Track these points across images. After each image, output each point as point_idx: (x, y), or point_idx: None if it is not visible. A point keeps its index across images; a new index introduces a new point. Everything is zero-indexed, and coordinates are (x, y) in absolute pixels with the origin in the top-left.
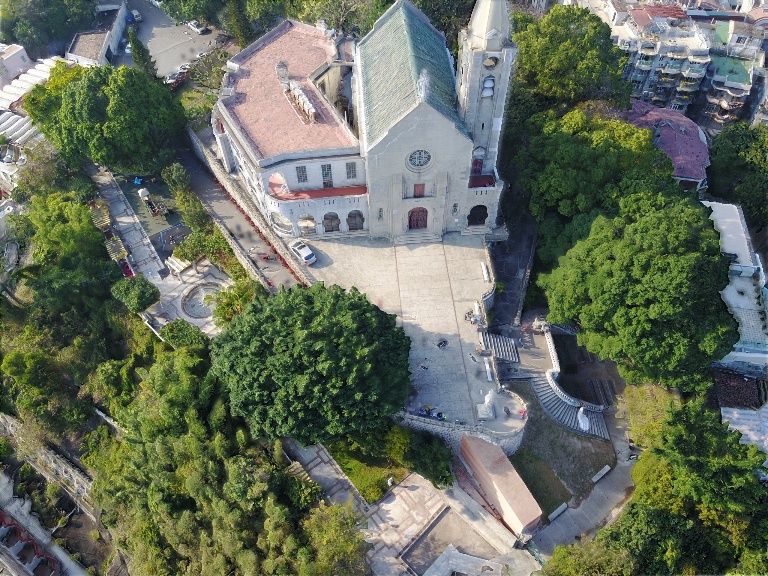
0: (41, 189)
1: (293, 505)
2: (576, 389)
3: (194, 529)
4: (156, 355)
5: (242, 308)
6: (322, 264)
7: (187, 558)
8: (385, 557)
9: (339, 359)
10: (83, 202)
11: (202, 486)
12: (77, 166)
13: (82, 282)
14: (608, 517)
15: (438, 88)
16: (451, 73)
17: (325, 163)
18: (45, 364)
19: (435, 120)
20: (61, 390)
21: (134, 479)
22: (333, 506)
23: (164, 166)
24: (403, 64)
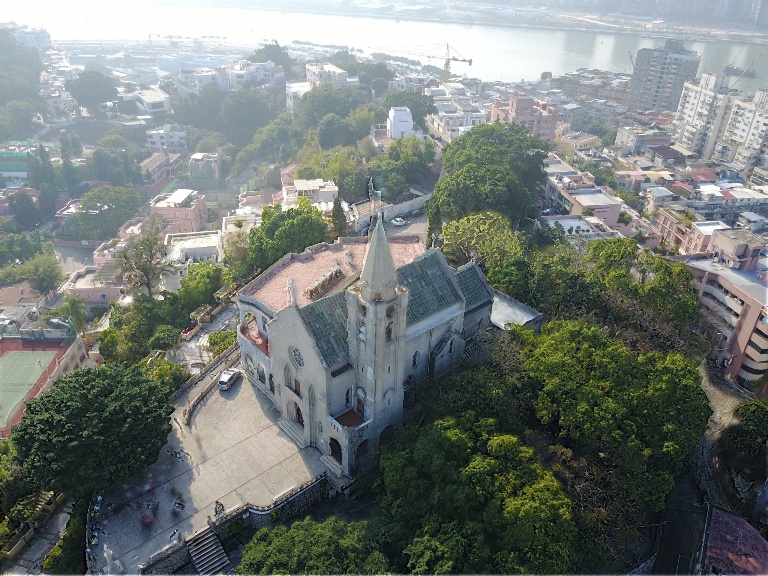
0: None
1: None
2: None
3: None
4: None
5: None
6: (227, 395)
7: None
8: None
9: None
10: None
11: None
12: None
13: (157, 313)
14: None
15: None
16: (413, 322)
17: None
18: (116, 347)
19: (302, 328)
20: None
21: None
22: None
23: None
24: None
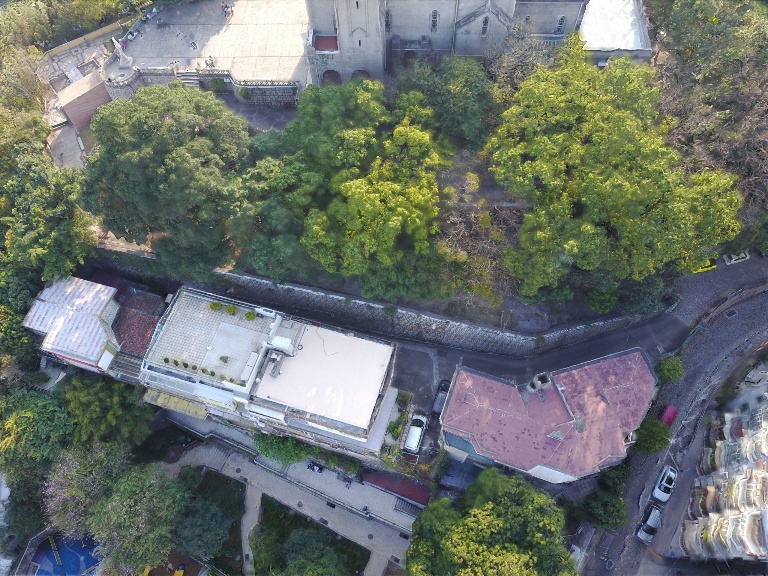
0: None
1: None
2: None
3: None
4: None
5: None
6: None
7: None
8: (97, 52)
9: None
10: None
11: None
12: None
13: None
14: None
15: None
16: None
17: None
18: None
19: None
20: None
21: None
22: None
23: None
24: None
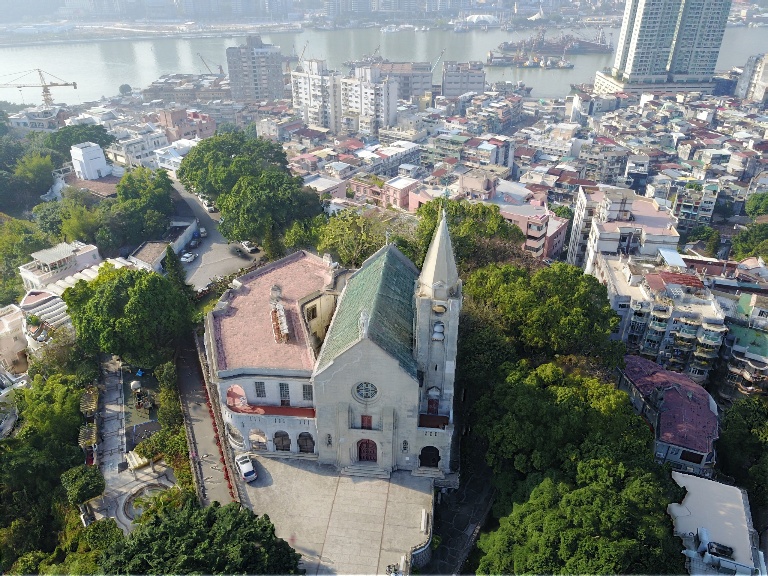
0: (55, 368)
1: None
2: None
3: None
4: None
5: None
6: (261, 483)
7: None
8: None
9: None
10: (82, 386)
11: None
12: (90, 352)
13: (39, 463)
14: None
15: (399, 326)
16: None
17: (283, 382)
18: None
19: (379, 356)
20: None
21: None
22: None
23: (161, 363)
24: (369, 301)
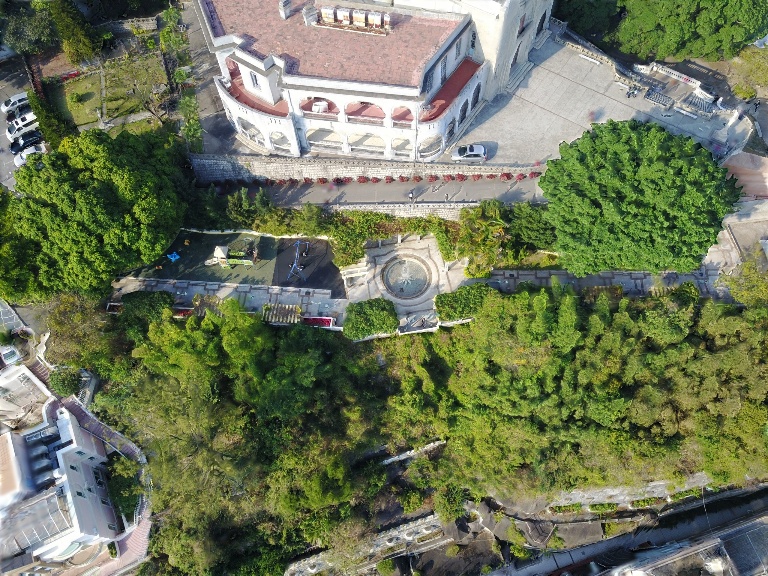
0: None
1: None
2: None
3: None
4: (439, 347)
5: None
6: (492, 151)
7: None
8: None
9: (691, 161)
10: None
11: (639, 362)
12: None
13: (317, 358)
14: None
15: None
16: None
17: None
18: None
19: None
20: None
21: None
22: None
23: None
24: None
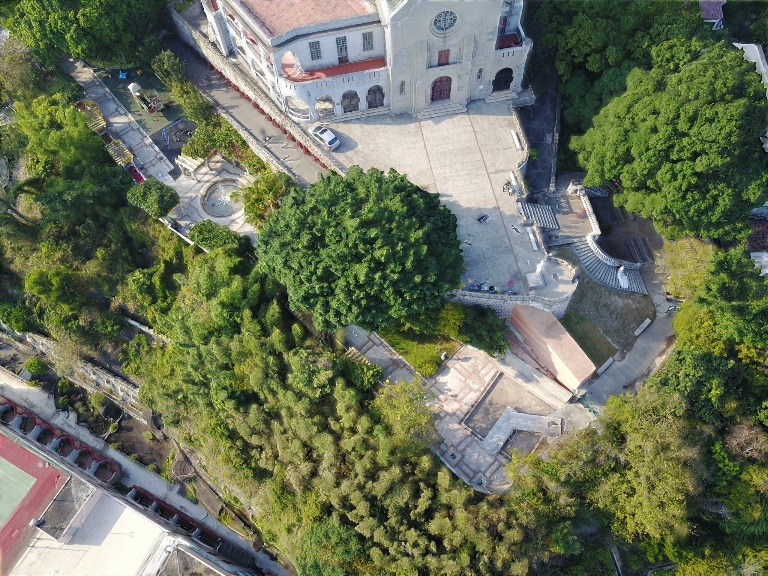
0: (18, 94)
1: (357, 388)
2: (611, 250)
3: (265, 420)
4: (186, 259)
5: (274, 202)
6: (346, 148)
7: (260, 447)
8: (449, 424)
9: (395, 244)
10: (70, 104)
11: (266, 380)
12: (53, 64)
13: (94, 191)
14: (652, 366)
15: None
16: None
17: (340, 35)
18: (70, 280)
19: None
20: (89, 304)
21: (191, 381)
22: (399, 384)
23: (152, 55)
24: None
